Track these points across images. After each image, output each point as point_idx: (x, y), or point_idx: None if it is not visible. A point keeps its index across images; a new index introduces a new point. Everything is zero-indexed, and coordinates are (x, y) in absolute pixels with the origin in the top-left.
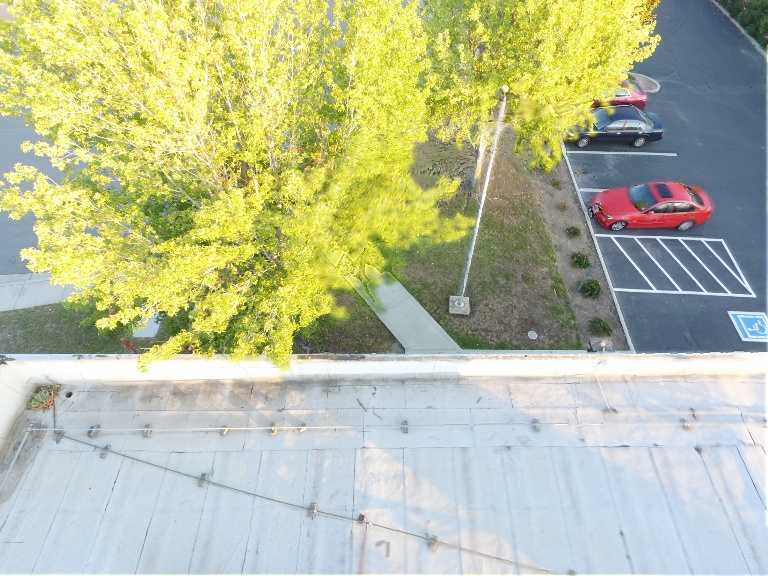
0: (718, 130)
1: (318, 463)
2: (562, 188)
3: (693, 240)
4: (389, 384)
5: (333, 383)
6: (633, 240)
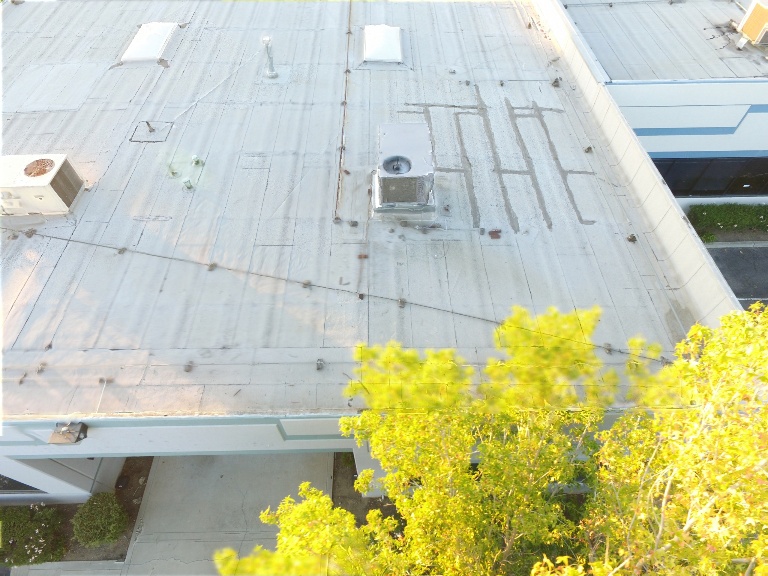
0: None
1: (402, 335)
2: None
3: None
4: None
5: None
6: None
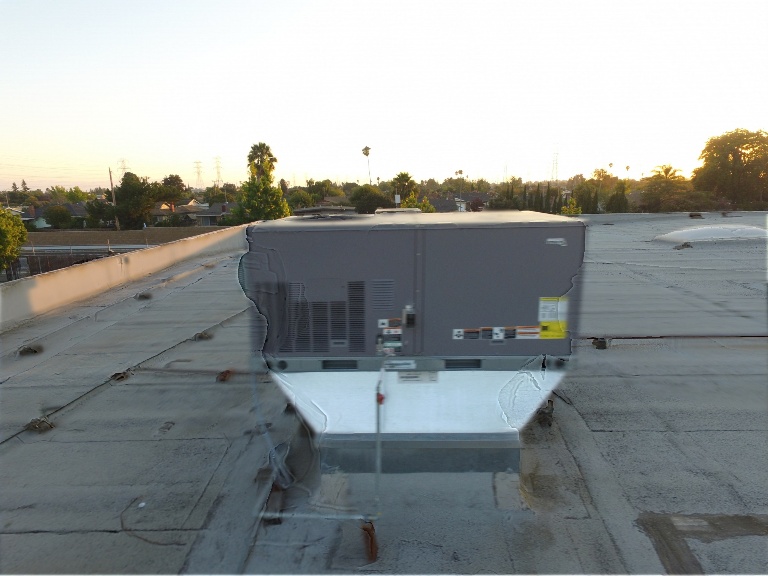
0: None
1: None
2: None
3: None
4: None
5: None
6: None
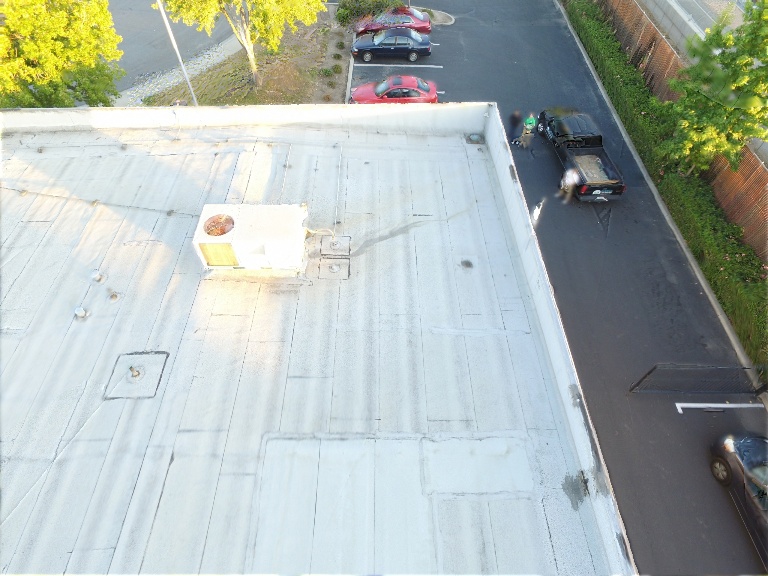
0: (486, 51)
1: None
2: (336, 88)
3: None
4: (45, 134)
5: (9, 134)
6: None
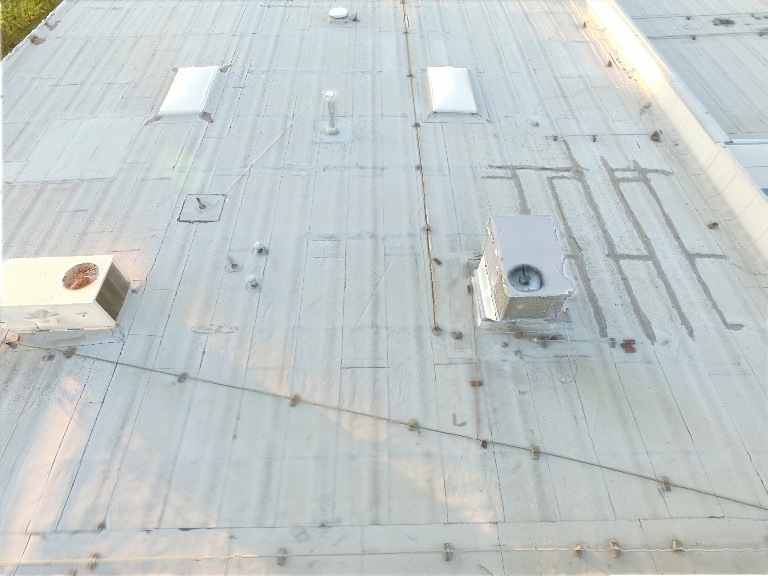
0: None
1: (545, 503)
2: None
3: None
4: None
5: None
6: None
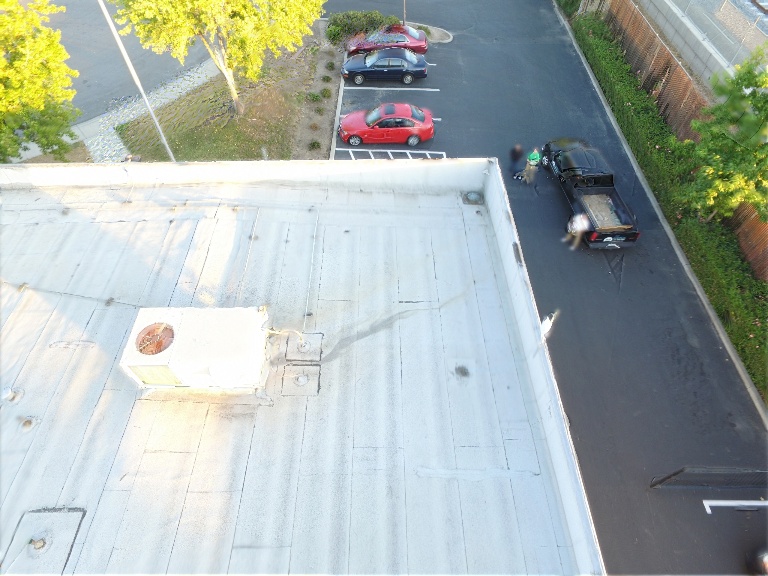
0: (486, 72)
1: None
2: (324, 114)
3: (419, 153)
4: None
5: None
6: (367, 153)
